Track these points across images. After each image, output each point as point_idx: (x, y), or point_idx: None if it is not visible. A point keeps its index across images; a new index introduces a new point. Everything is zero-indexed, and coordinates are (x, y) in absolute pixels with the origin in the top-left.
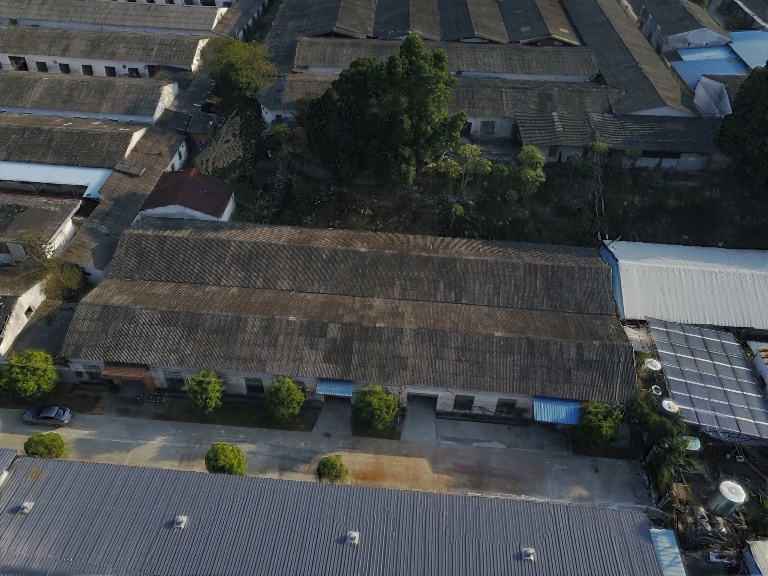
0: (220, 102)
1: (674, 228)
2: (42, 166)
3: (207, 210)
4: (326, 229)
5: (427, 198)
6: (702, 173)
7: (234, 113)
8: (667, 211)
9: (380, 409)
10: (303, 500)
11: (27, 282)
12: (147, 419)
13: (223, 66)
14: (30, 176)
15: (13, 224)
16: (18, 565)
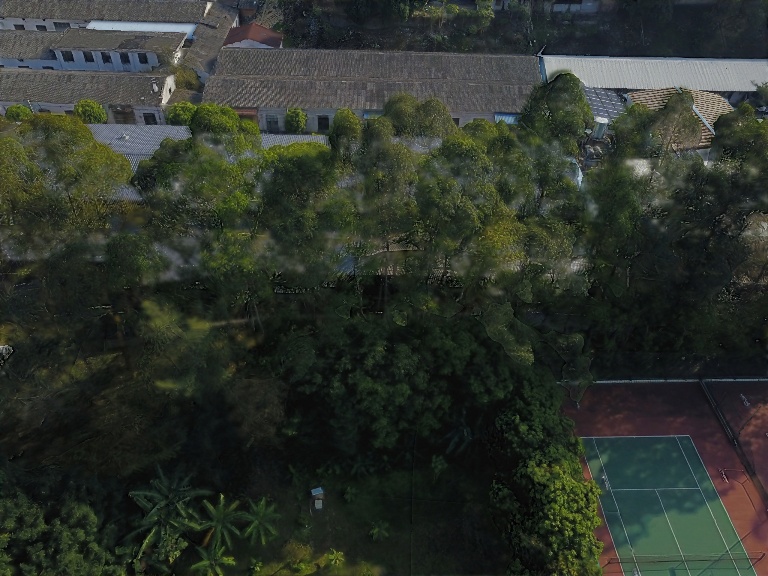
0: None
1: (580, 49)
2: (146, 23)
3: (269, 44)
4: (352, 50)
5: (416, 36)
6: (597, 14)
7: None
8: (575, 39)
9: None
10: None
11: (167, 73)
12: None
13: None
14: (140, 28)
15: (148, 44)
16: None
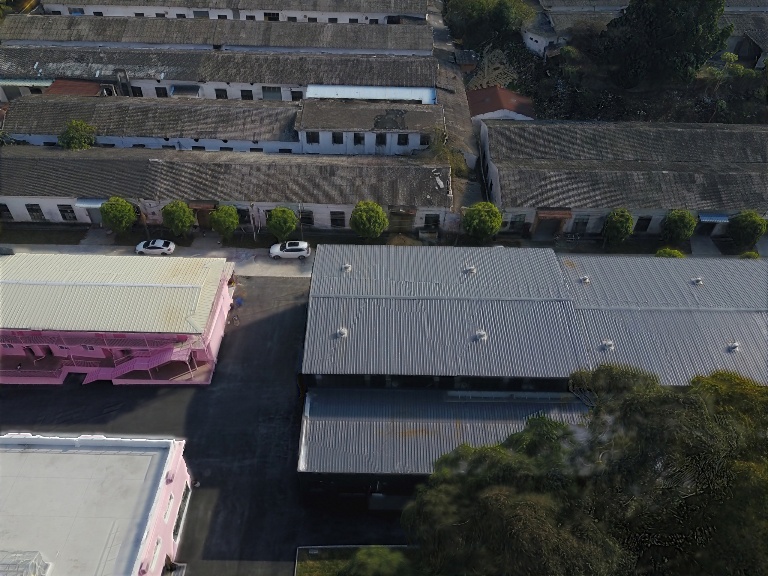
0: (463, 42)
1: None
2: (373, 88)
3: (526, 113)
4: (629, 122)
5: (686, 100)
6: None
7: (487, 48)
8: None
9: (761, 225)
10: (767, 267)
11: (441, 160)
12: (566, 253)
13: (496, 5)
14: (370, 95)
15: (407, 121)
16: (615, 306)
